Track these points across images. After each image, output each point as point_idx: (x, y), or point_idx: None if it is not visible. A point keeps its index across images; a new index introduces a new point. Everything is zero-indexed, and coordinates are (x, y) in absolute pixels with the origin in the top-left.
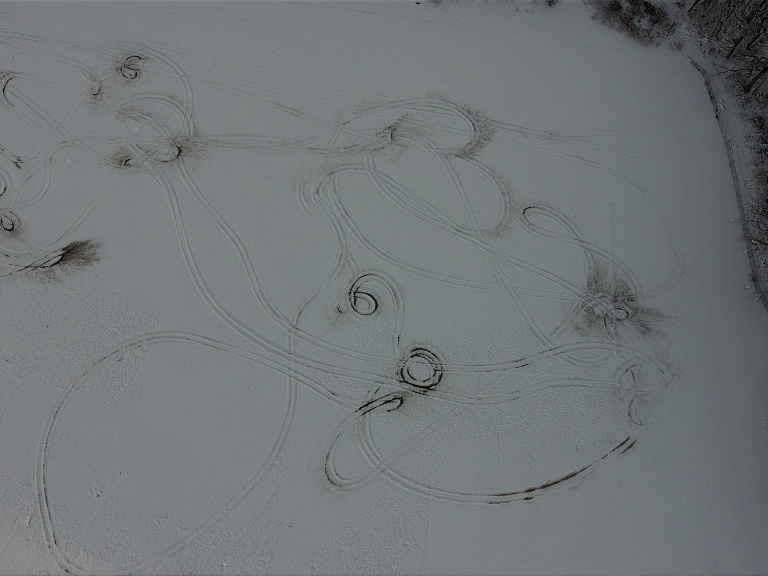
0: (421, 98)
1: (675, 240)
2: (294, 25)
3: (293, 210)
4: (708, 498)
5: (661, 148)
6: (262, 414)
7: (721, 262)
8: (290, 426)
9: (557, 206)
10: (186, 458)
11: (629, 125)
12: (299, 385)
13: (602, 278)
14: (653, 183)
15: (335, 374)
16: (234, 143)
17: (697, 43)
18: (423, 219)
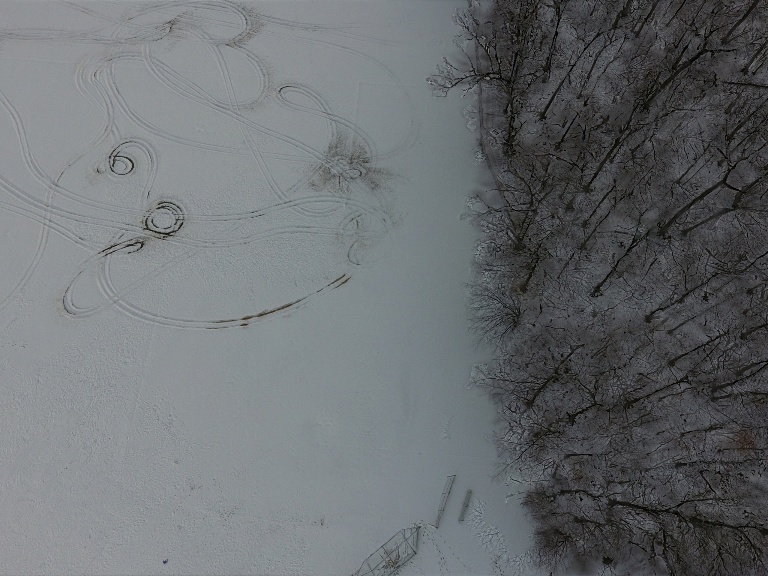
0: None
1: (414, 112)
2: None
3: (70, 89)
4: (409, 324)
5: (415, 37)
6: (14, 255)
7: (454, 130)
8: (37, 265)
9: (311, 85)
10: None
11: (388, 18)
12: (51, 231)
13: (342, 144)
14: (402, 66)
15: (85, 223)
16: (27, 36)
17: None
18: (187, 96)
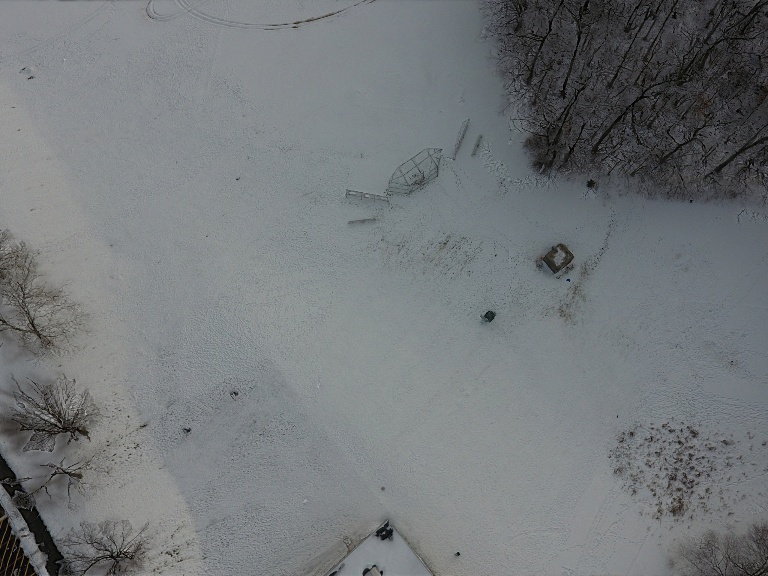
0: None
1: None
2: None
3: None
4: (430, 27)
5: None
6: None
7: None
8: None
9: None
10: (44, 2)
11: None
12: None
13: None
14: None
15: None
16: None
17: None
18: None
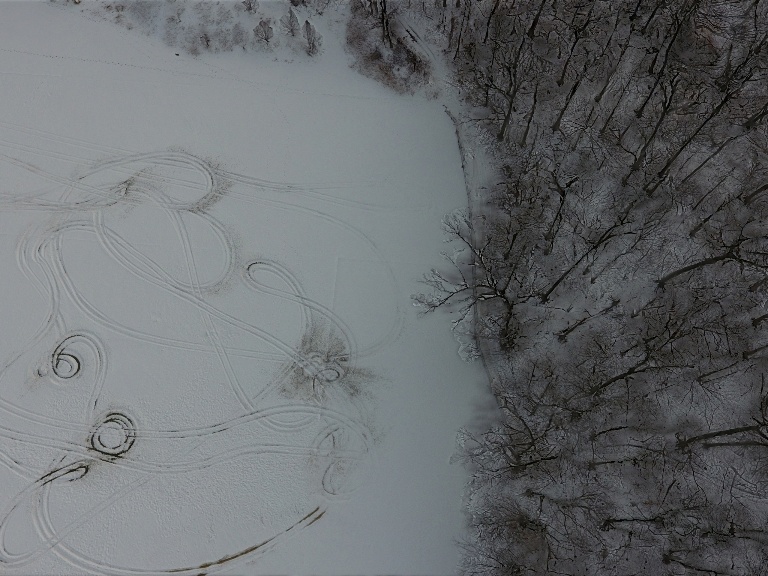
0: (163, 151)
1: (400, 296)
2: (47, 79)
3: (11, 269)
4: (391, 574)
5: (401, 200)
6: None
7: (444, 319)
8: None
9: (283, 261)
10: None
11: (371, 176)
12: None
13: (318, 337)
14: (386, 236)
15: (22, 441)
16: None
17: (456, 91)
18: (143, 276)
